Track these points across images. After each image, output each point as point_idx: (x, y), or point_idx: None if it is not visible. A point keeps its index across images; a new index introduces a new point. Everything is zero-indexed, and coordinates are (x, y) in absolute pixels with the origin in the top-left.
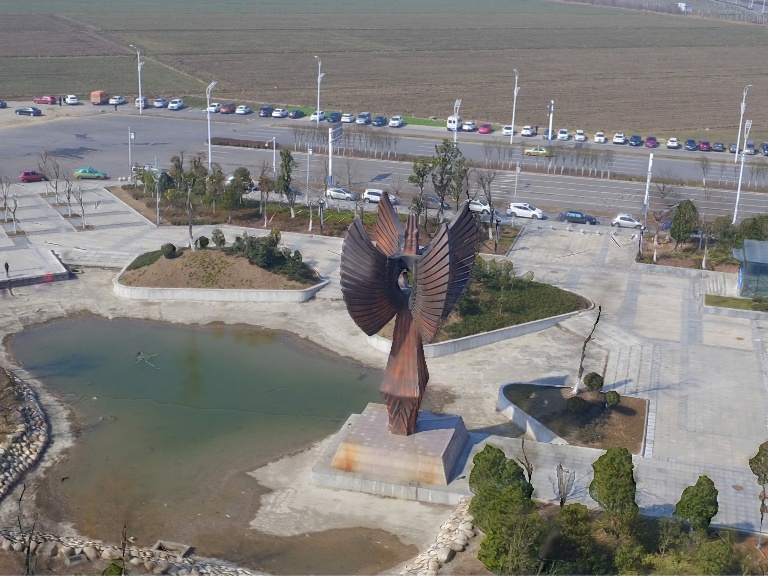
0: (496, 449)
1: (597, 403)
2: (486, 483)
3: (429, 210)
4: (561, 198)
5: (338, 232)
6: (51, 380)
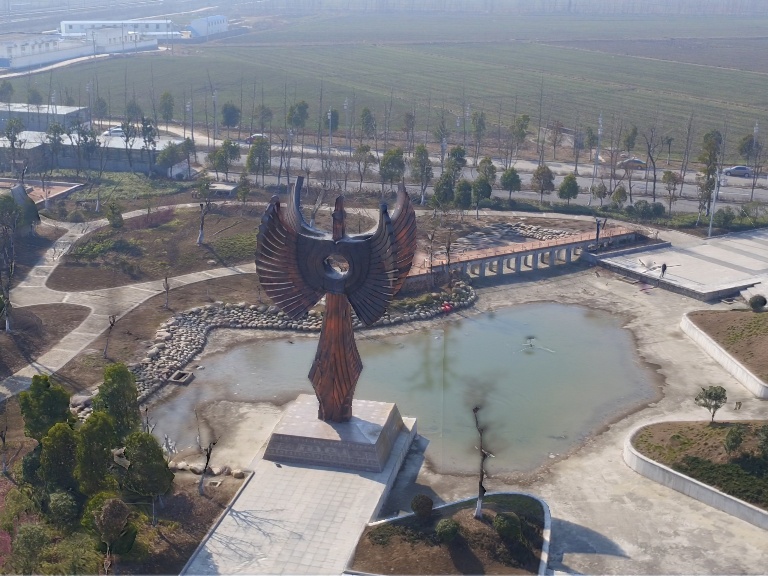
0: (114, 367)
1: None
2: None
3: None
4: None
5: None
6: (467, 323)
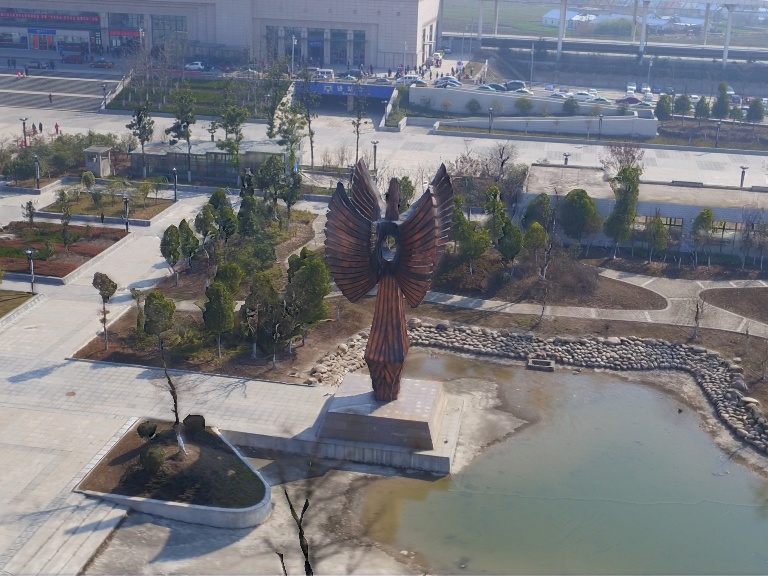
0: (314, 260)
1: (164, 438)
2: None
3: None
4: None
5: None
6: None
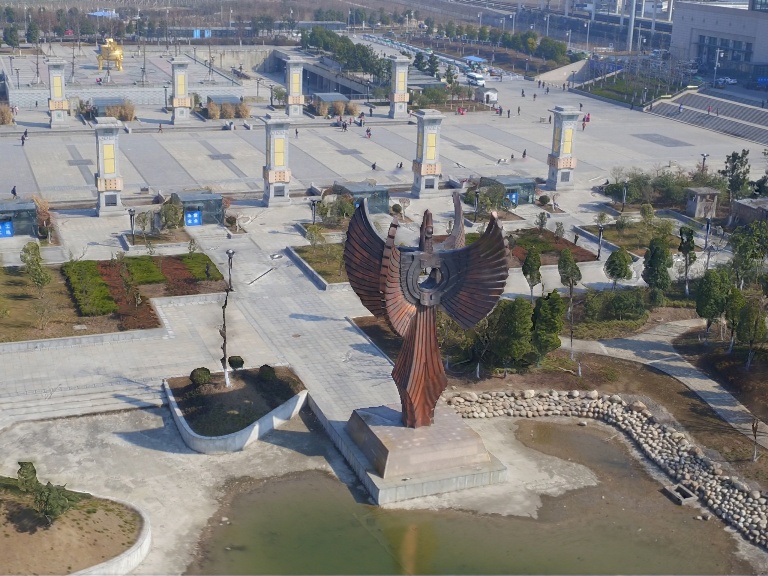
0: None
1: (240, 373)
2: None
3: None
4: None
5: None
6: None
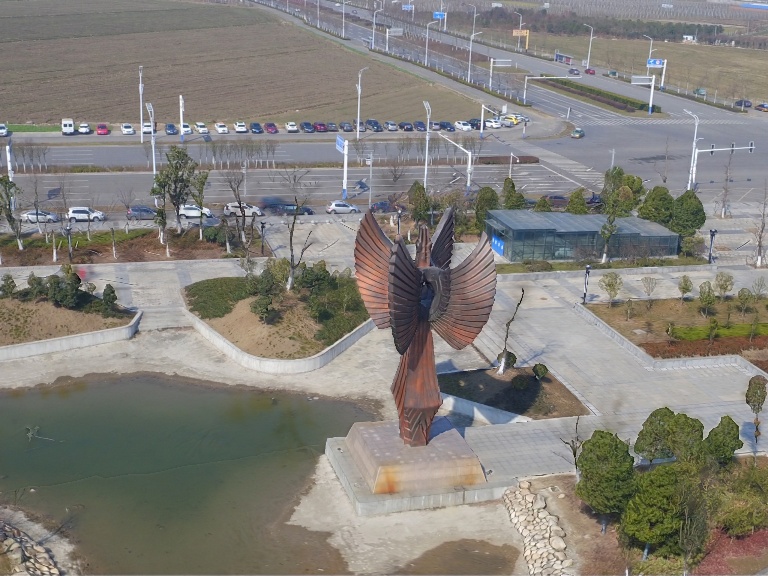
0: (608, 433)
1: (528, 378)
2: (602, 466)
3: (146, 221)
4: (254, 193)
5: (88, 258)
6: None
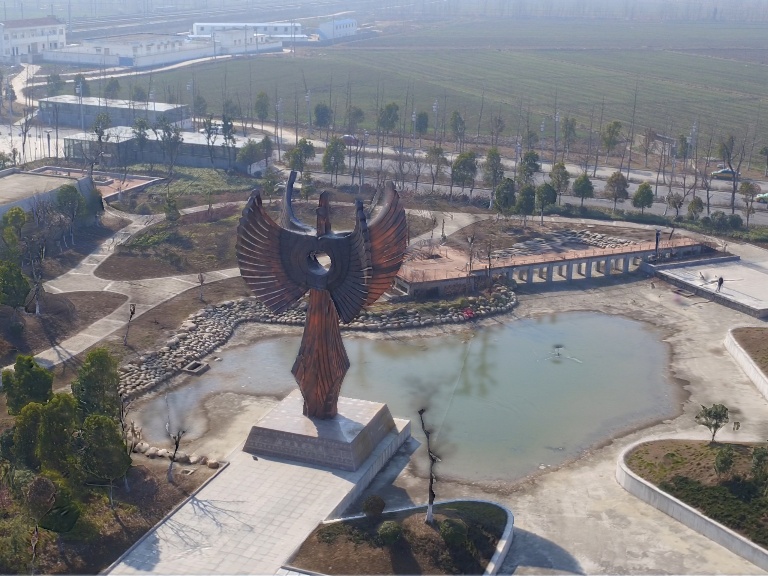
0: None
1: None
2: None
3: None
4: None
5: None
6: (500, 328)
